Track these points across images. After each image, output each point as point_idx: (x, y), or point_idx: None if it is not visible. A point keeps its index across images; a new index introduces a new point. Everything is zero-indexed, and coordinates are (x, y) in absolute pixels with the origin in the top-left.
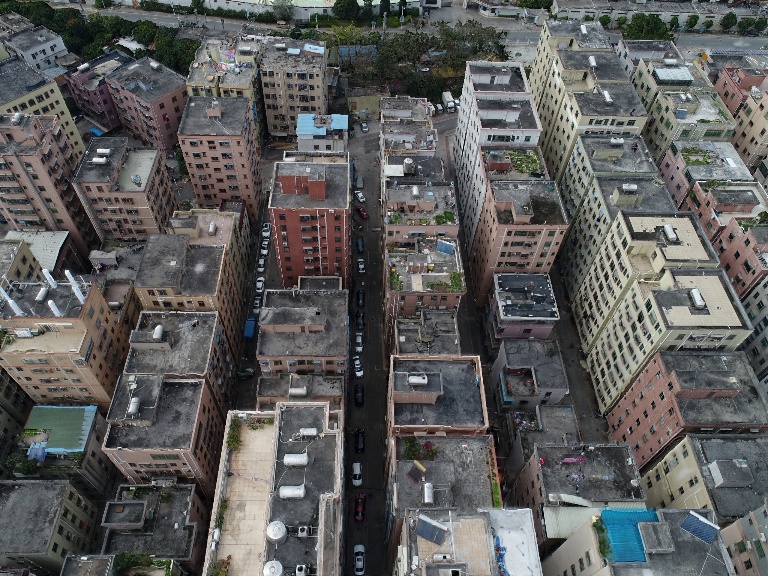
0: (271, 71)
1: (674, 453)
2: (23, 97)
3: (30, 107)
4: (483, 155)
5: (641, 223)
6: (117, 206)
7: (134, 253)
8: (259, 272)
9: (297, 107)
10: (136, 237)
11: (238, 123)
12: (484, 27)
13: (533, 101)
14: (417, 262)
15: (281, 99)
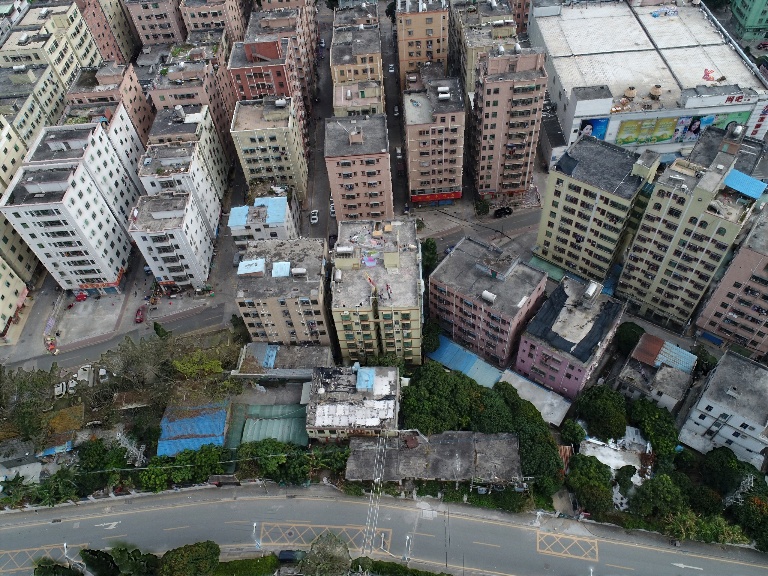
0: None
1: (104, 7)
2: (569, 149)
3: None
4: None
5: (36, 46)
6: None
7: None
8: None
9: None
10: None
11: (333, 135)
12: None
13: (26, 156)
14: (197, 49)
15: None
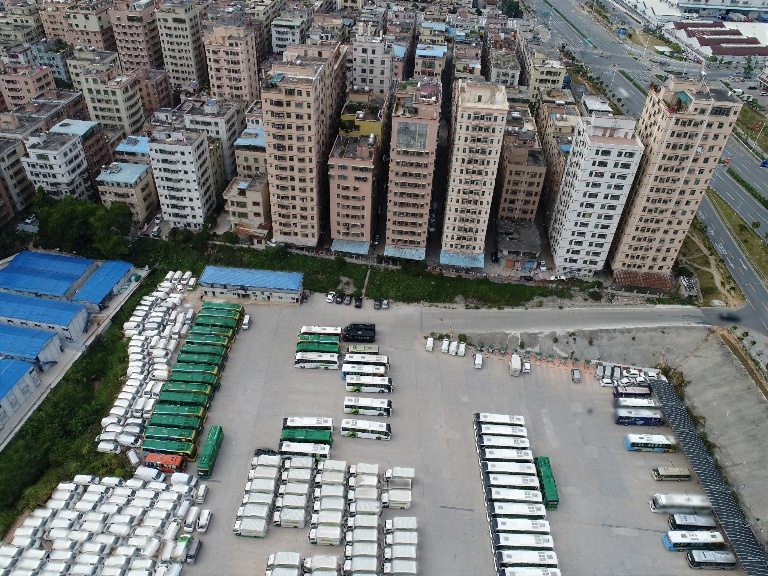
0: None
1: None
2: None
3: None
4: None
5: None
6: None
7: None
8: None
9: None
10: None
11: None
12: None
13: None
14: None
15: None
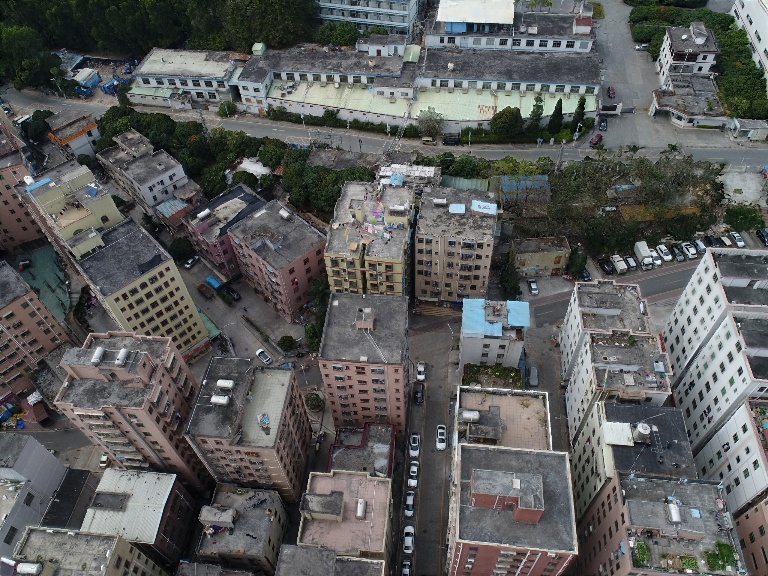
0: (429, 238)
1: None
2: (134, 282)
3: (141, 290)
4: (753, 417)
5: None
6: (238, 456)
7: (254, 507)
8: (407, 516)
9: (456, 274)
10: (257, 479)
11: (395, 338)
12: (680, 143)
13: None
14: None
15: (437, 266)
